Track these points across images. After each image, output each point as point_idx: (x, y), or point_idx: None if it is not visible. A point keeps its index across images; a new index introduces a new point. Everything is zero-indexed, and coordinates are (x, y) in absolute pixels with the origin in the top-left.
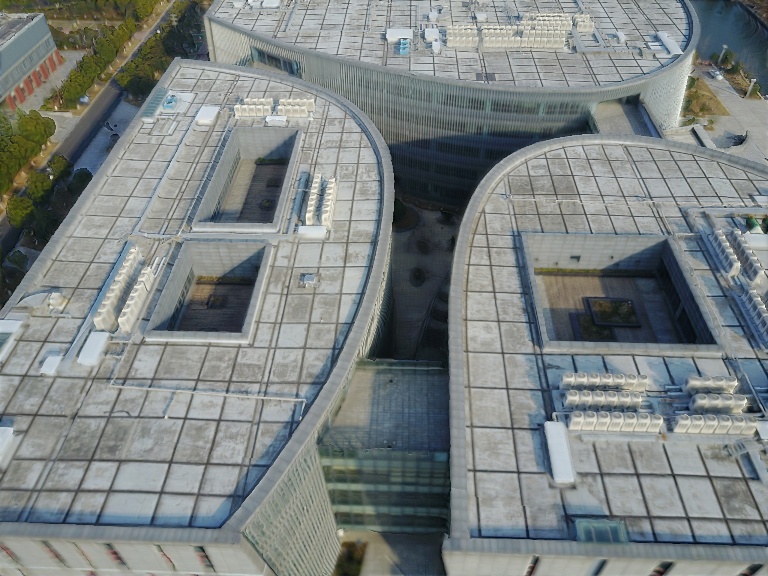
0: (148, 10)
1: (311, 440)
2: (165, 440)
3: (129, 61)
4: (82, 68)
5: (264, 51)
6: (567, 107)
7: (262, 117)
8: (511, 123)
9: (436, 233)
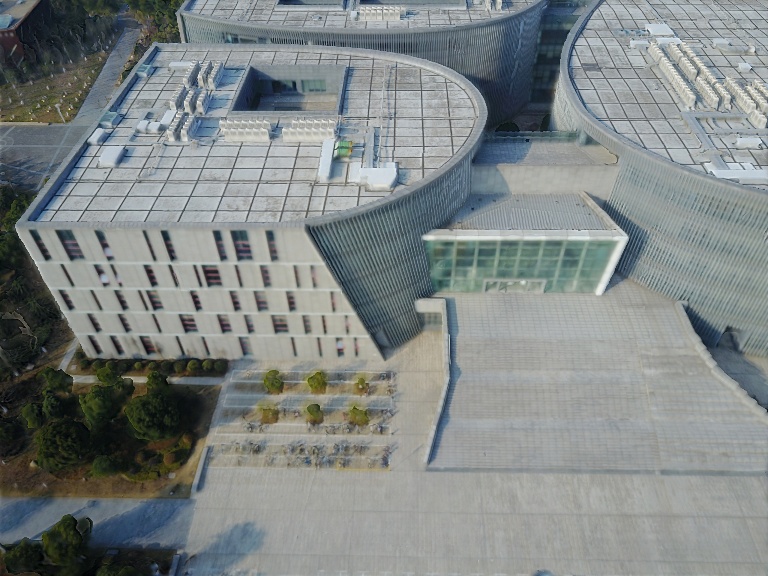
0: None
1: (220, 28)
2: (228, 2)
3: None
4: None
5: None
6: None
7: None
8: None
9: None
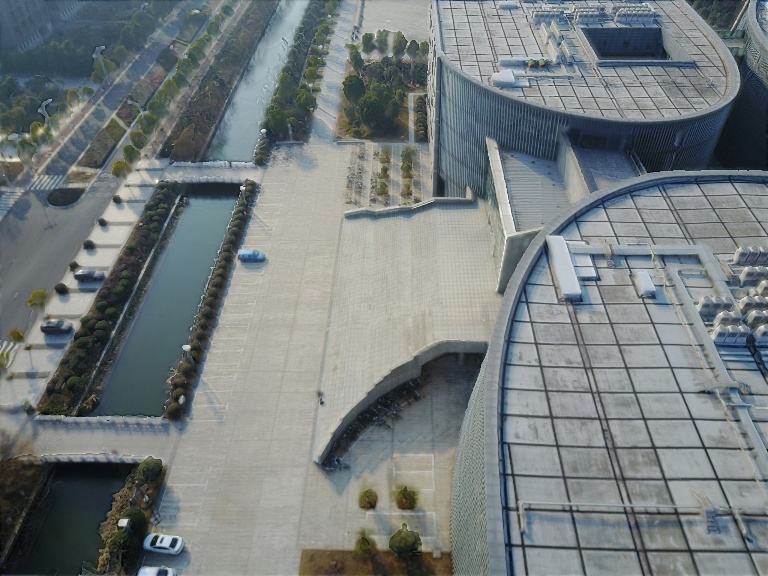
0: None
1: None
2: None
3: None
4: None
5: None
6: None
7: None
8: None
9: None
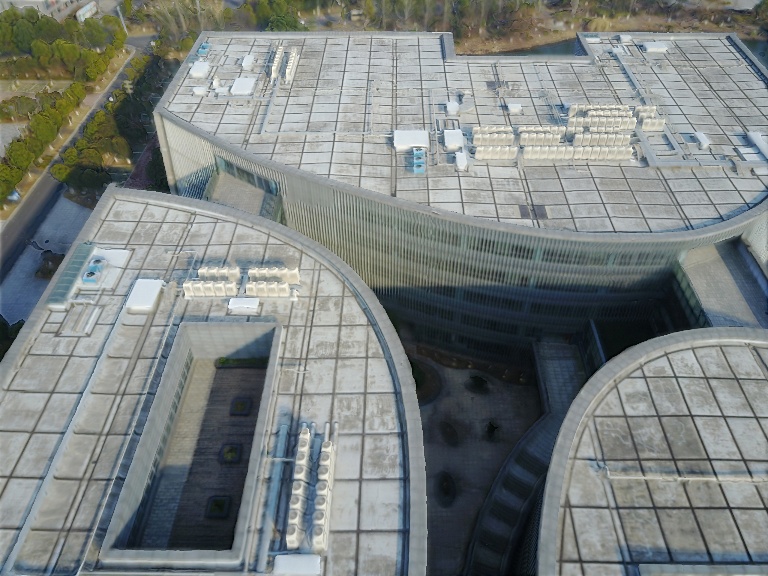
0: (101, 68)
1: None
2: None
3: (75, 137)
4: (11, 156)
5: (232, 163)
6: (648, 257)
7: (224, 298)
8: (569, 276)
9: (465, 408)
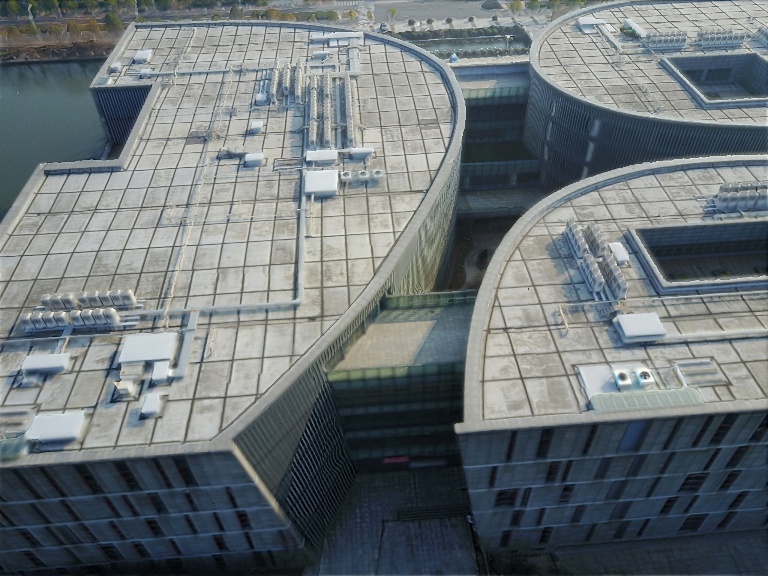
0: None
1: None
2: None
3: None
4: None
5: None
6: None
7: None
8: None
9: None
